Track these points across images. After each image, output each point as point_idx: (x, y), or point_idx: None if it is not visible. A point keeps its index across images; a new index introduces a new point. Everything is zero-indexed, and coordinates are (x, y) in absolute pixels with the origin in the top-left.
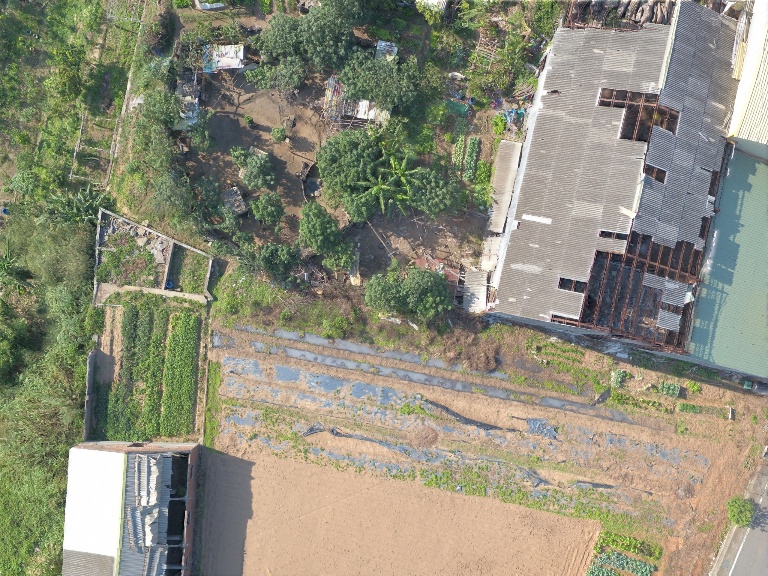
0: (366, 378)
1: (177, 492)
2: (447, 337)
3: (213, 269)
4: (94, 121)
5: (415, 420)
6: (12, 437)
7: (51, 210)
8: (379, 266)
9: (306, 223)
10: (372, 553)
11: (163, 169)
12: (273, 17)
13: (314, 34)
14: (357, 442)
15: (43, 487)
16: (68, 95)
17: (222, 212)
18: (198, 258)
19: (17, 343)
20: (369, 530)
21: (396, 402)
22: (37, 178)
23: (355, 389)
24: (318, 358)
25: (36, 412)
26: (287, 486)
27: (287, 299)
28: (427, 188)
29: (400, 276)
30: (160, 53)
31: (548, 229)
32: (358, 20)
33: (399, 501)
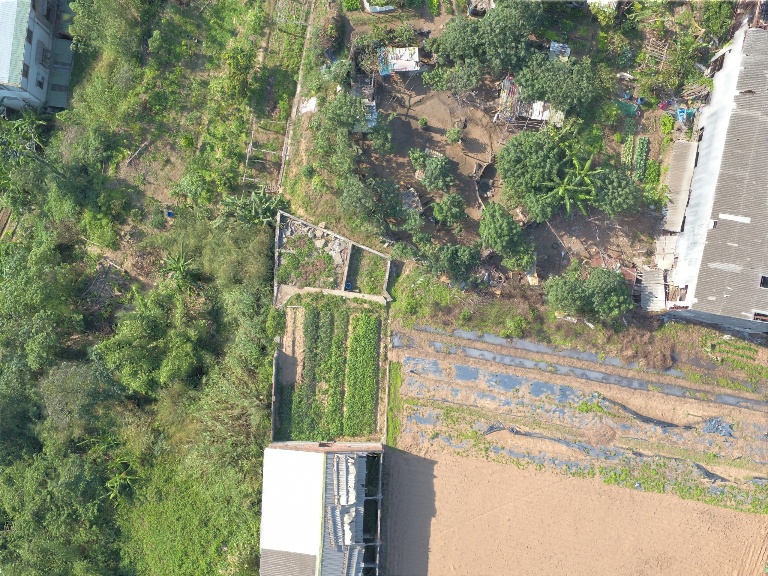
0: (544, 377)
1: (368, 491)
2: (623, 336)
3: (390, 270)
4: (259, 124)
5: (593, 418)
6: (200, 438)
7: (228, 213)
8: (553, 266)
9: (491, 224)
10: (554, 550)
11: (346, 171)
12: (451, 19)
13: (496, 36)
14: (537, 440)
15: (236, 487)
16: (237, 98)
17: (402, 213)
18: (375, 259)
19: (197, 345)
20: (550, 527)
21: (574, 400)
22: (204, 181)
23: (533, 388)
24: (497, 357)
25: (224, 413)
26: (469, 484)
27: (466, 299)
28: (609, 188)
29: (581, 275)
30: (332, 56)
31: (747, 228)
32: (535, 22)
33: (579, 498)
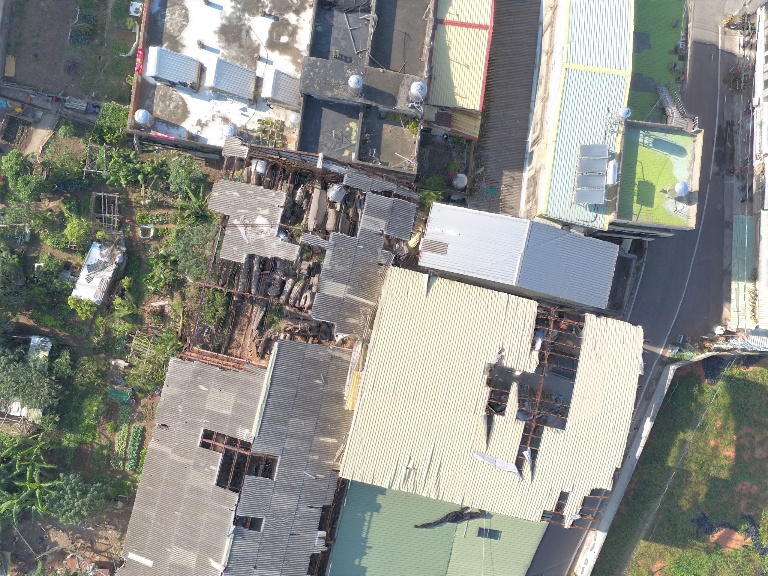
0: None
1: None
2: None
3: None
4: None
5: None
6: None
7: None
8: (37, 561)
9: None
10: None
11: None
12: None
13: None
14: None
15: None
16: None
17: None
18: None
19: None
20: None
21: None
22: None
23: None
24: None
25: None
26: None
27: None
28: (65, 499)
29: None
30: None
31: (149, 572)
32: None
33: None
